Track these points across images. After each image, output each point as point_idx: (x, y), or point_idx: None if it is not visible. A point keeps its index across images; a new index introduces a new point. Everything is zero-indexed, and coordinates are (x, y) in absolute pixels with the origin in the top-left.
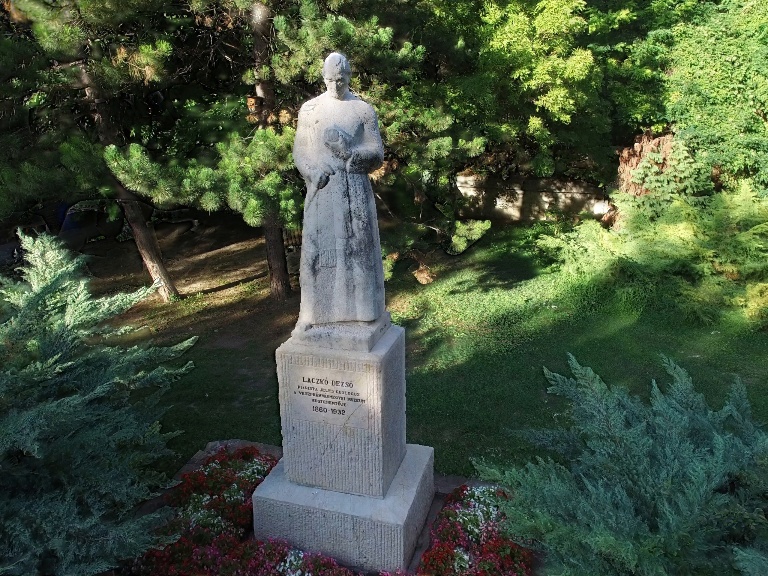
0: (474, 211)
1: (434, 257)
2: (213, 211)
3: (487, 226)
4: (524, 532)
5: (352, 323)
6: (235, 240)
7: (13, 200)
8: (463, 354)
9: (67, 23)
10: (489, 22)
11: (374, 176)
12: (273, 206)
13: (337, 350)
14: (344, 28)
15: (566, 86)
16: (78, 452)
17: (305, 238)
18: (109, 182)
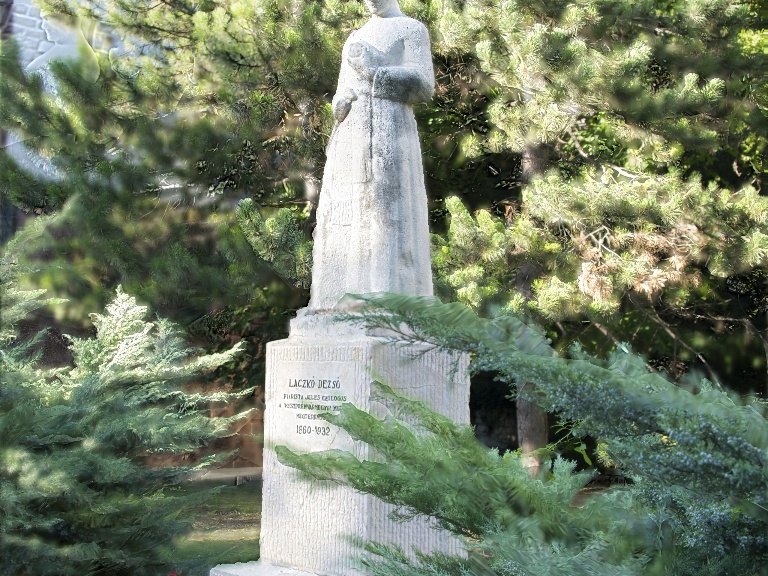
0: None
1: None
2: None
3: None
4: (342, 415)
5: None
6: None
7: (163, 300)
8: None
9: (260, 89)
10: None
11: (646, 286)
12: None
13: None
14: (562, 42)
15: None
16: (4, 418)
17: None
18: (268, 277)
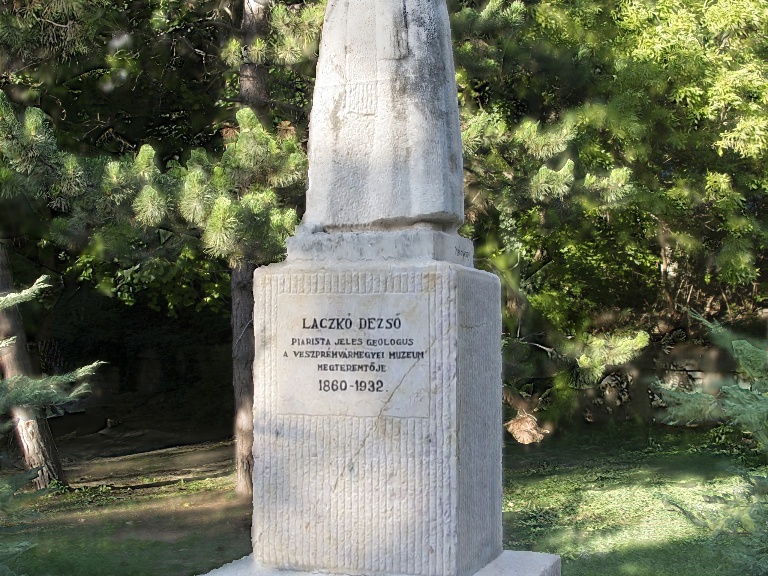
0: (612, 412)
1: (541, 457)
2: (152, 221)
3: (641, 341)
4: None
5: (400, 227)
6: (176, 443)
7: None
8: (607, 544)
9: None
10: (628, 27)
11: None
12: (256, 234)
13: (371, 260)
14: None
15: (767, 115)
16: None
17: (321, 65)
18: None
